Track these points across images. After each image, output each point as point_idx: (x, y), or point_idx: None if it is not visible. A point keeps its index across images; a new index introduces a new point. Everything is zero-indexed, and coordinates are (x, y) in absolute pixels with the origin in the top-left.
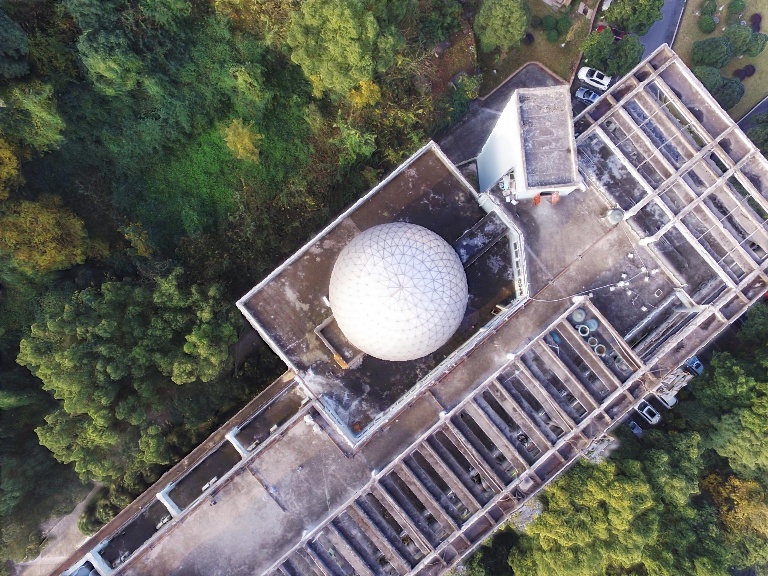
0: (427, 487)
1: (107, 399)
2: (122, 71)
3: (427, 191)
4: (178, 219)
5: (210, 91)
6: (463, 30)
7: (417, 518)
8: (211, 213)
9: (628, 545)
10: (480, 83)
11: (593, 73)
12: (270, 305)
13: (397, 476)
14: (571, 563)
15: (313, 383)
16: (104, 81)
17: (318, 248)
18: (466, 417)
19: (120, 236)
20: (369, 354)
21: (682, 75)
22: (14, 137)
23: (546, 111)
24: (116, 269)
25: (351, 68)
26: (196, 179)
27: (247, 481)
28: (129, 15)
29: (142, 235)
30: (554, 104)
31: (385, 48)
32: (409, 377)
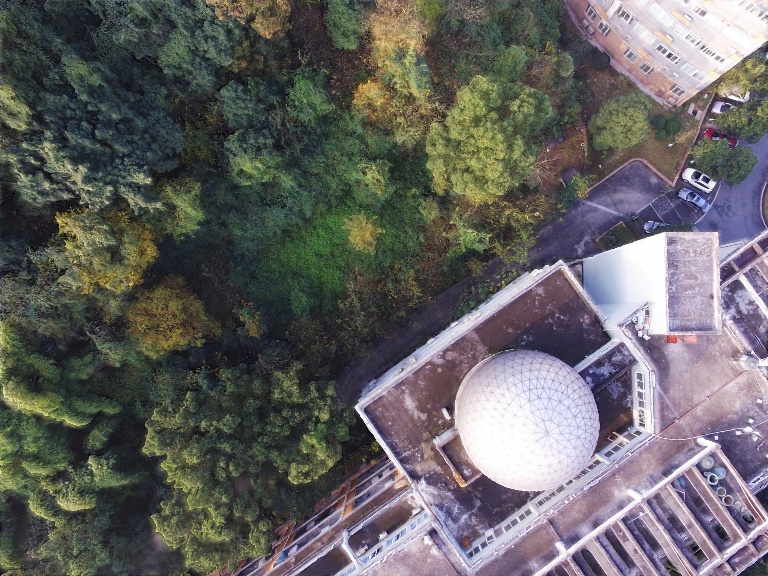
0: None
1: (228, 496)
2: (264, 169)
3: (553, 311)
4: (286, 298)
5: (335, 182)
6: (576, 126)
7: None
8: (317, 294)
9: None
10: None
11: (698, 176)
12: (389, 411)
13: None
14: None
15: (425, 493)
16: (244, 175)
17: (440, 358)
18: (582, 549)
19: (231, 313)
20: None
21: None
22: (156, 226)
23: (692, 256)
24: (224, 345)
25: (486, 182)
26: (307, 260)
27: None
28: (277, 115)
29: (256, 317)
30: (700, 249)
31: (523, 166)
32: (520, 496)
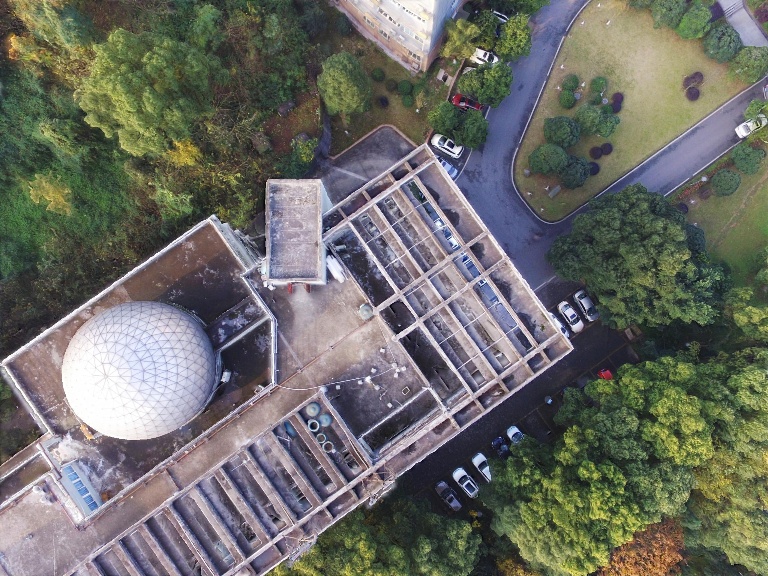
0: (143, 569)
1: None
2: None
3: (202, 265)
4: None
5: (22, 142)
6: (310, 91)
7: None
8: (31, 257)
9: None
10: (329, 143)
11: (445, 141)
12: (35, 366)
13: None
14: None
15: (70, 447)
16: None
17: (88, 313)
18: None
19: None
20: None
21: (441, 176)
22: None
23: (297, 203)
24: None
25: (140, 136)
26: (17, 223)
27: None
28: None
29: None
30: (306, 197)
31: (172, 120)
32: (165, 449)
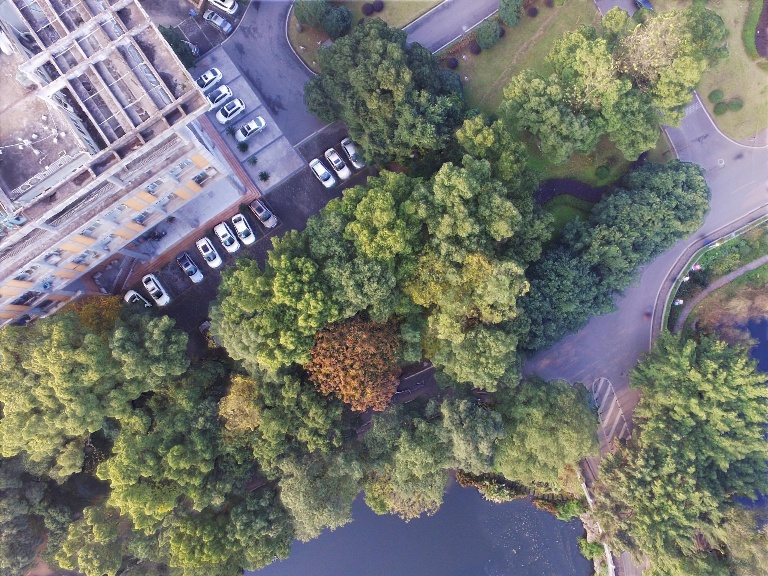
0: None
1: None
2: None
3: None
4: None
5: None
6: None
7: None
8: None
9: (67, 414)
10: None
11: None
12: None
13: None
14: (16, 428)
15: None
16: None
17: None
18: None
19: None
20: None
21: None
22: None
23: None
24: None
25: None
26: None
27: None
28: None
29: None
30: None
31: None
32: None
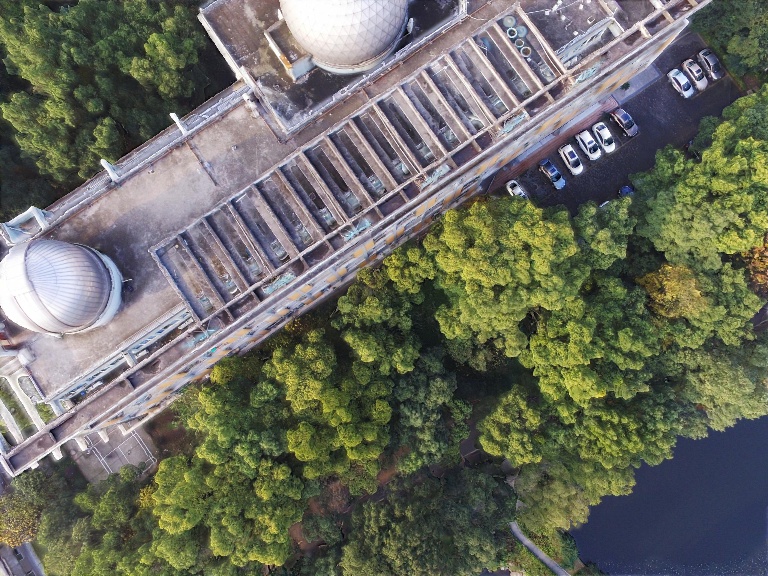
0: (349, 163)
1: (68, 75)
2: None
3: None
4: None
5: None
6: None
7: (336, 191)
8: None
9: (548, 288)
10: None
11: None
12: (228, 19)
13: (325, 164)
14: (492, 302)
15: None
16: None
17: None
18: (396, 117)
19: None
20: (309, 41)
21: None
22: None
23: None
24: None
25: None
26: None
27: (185, 155)
28: None
29: None
30: None
31: None
32: None
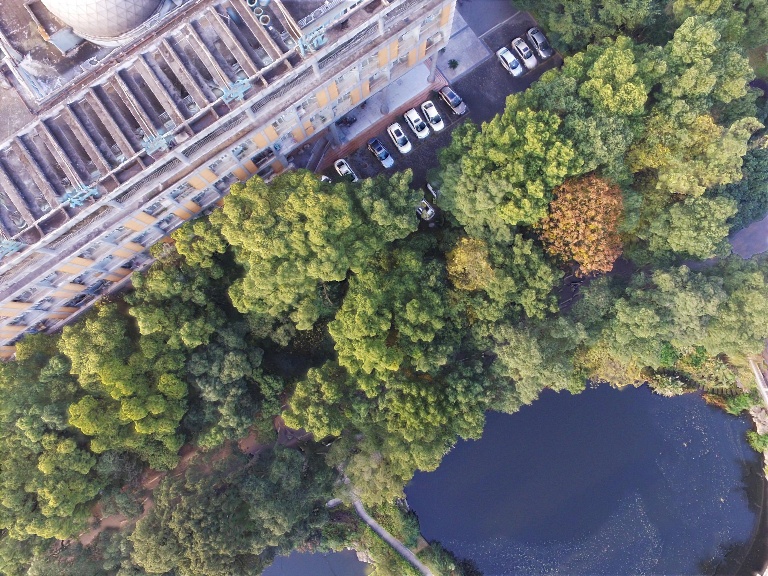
0: (89, 132)
1: None
2: None
3: None
4: None
5: None
6: None
7: (76, 159)
8: None
9: (322, 259)
10: None
11: None
12: None
13: None
14: (268, 274)
15: (30, 67)
16: None
17: None
18: (147, 87)
19: None
20: (55, 12)
21: None
22: None
23: None
24: None
25: None
26: None
27: None
28: None
29: None
30: None
31: None
32: None
